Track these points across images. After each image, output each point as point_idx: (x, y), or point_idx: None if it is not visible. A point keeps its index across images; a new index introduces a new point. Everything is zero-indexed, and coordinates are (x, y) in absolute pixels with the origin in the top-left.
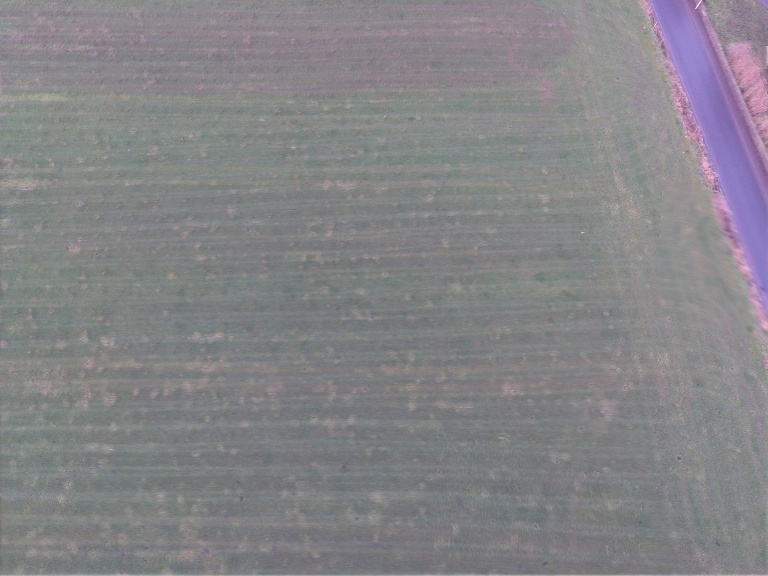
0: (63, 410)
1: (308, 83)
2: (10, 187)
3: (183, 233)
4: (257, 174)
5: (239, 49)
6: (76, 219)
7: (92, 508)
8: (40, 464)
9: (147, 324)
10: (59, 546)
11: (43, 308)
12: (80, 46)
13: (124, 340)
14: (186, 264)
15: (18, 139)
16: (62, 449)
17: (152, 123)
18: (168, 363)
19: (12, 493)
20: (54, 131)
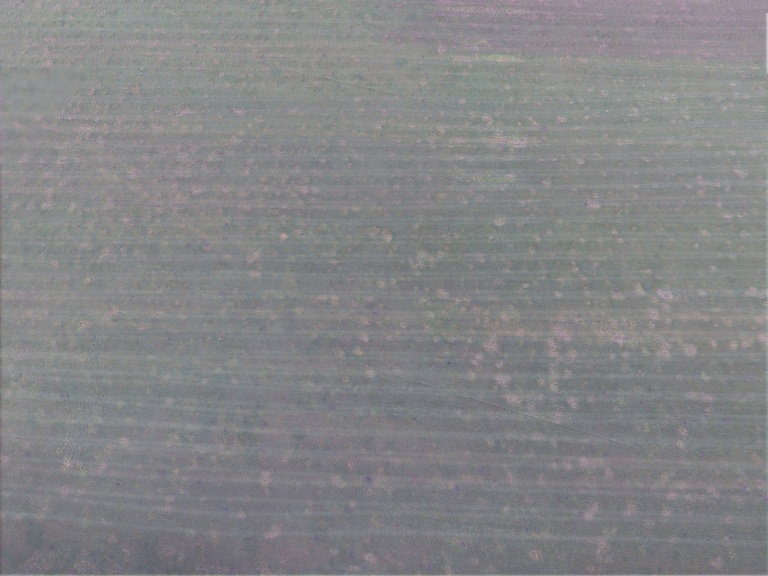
0: (646, 359)
1: (765, 50)
2: (500, 144)
3: (699, 191)
4: (750, 136)
5: (682, 16)
6: (583, 176)
7: (717, 454)
8: (645, 411)
9: (699, 278)
10: (698, 490)
11: (585, 261)
12: (516, 10)
13: (681, 293)
14: (714, 221)
15: (489, 98)
16: (661, 397)
17: (621, 85)
18: (735, 316)
19: (627, 438)
20: (523, 91)
